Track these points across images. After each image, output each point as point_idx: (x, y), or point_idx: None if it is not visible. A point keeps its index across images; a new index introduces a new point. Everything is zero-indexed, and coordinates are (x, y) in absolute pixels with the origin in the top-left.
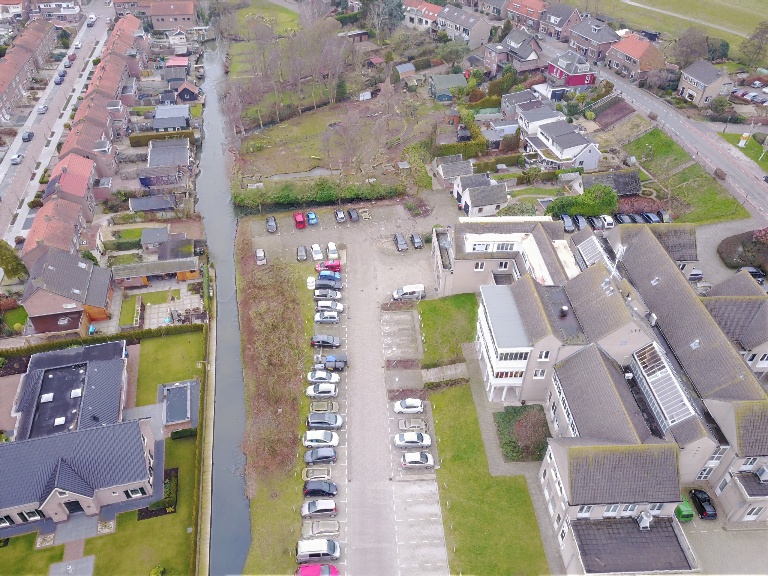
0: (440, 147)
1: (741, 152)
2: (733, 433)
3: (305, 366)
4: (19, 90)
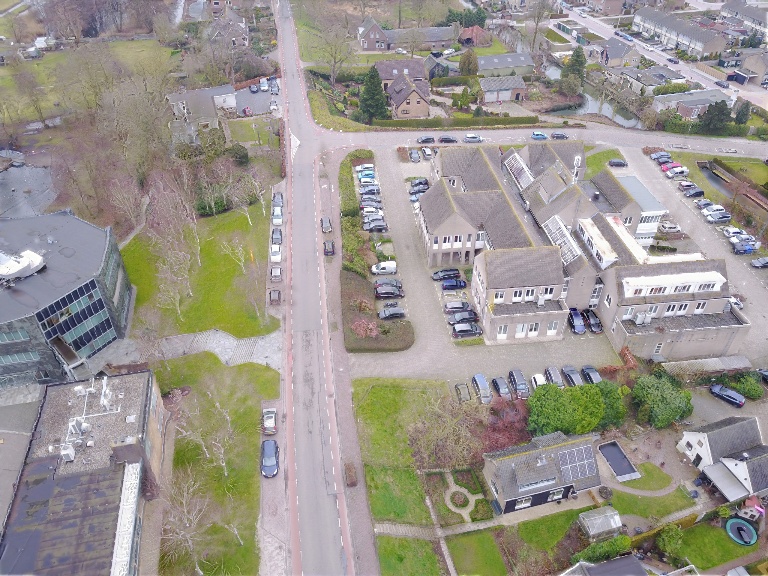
0: None
1: (261, 572)
2: None
3: (763, 249)
4: None
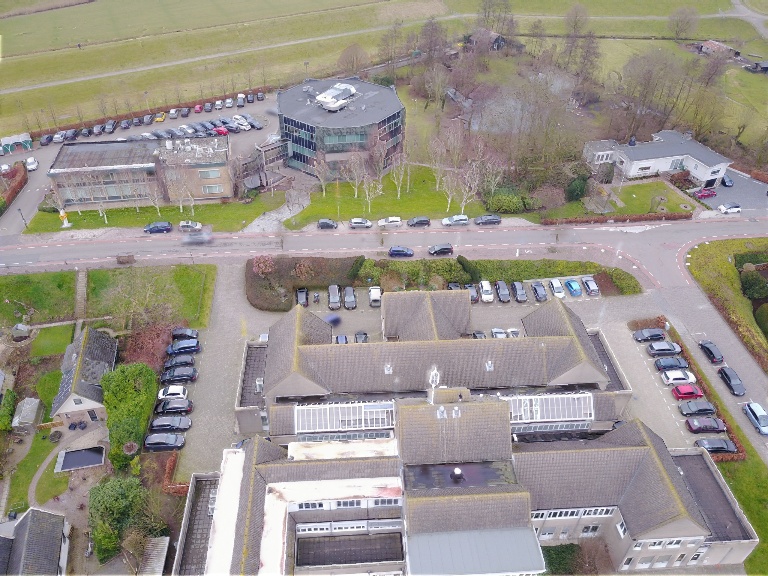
0: None
1: (83, 230)
2: (596, 375)
3: None
4: None
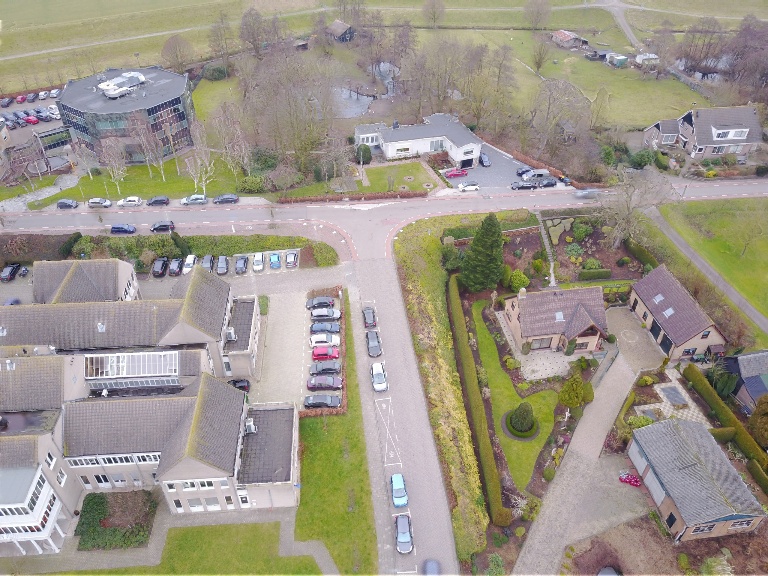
0: None
1: None
2: (201, 335)
3: None
4: None
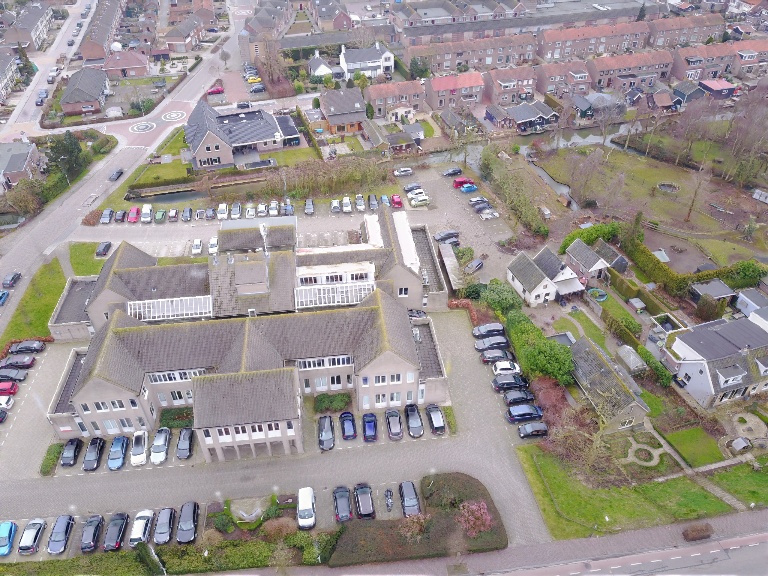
0: (637, 244)
1: None
2: None
3: None
4: (597, 47)
